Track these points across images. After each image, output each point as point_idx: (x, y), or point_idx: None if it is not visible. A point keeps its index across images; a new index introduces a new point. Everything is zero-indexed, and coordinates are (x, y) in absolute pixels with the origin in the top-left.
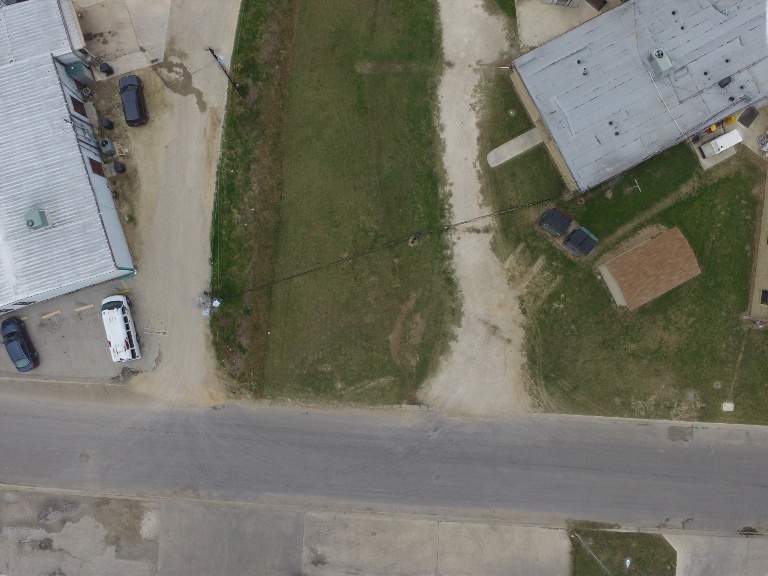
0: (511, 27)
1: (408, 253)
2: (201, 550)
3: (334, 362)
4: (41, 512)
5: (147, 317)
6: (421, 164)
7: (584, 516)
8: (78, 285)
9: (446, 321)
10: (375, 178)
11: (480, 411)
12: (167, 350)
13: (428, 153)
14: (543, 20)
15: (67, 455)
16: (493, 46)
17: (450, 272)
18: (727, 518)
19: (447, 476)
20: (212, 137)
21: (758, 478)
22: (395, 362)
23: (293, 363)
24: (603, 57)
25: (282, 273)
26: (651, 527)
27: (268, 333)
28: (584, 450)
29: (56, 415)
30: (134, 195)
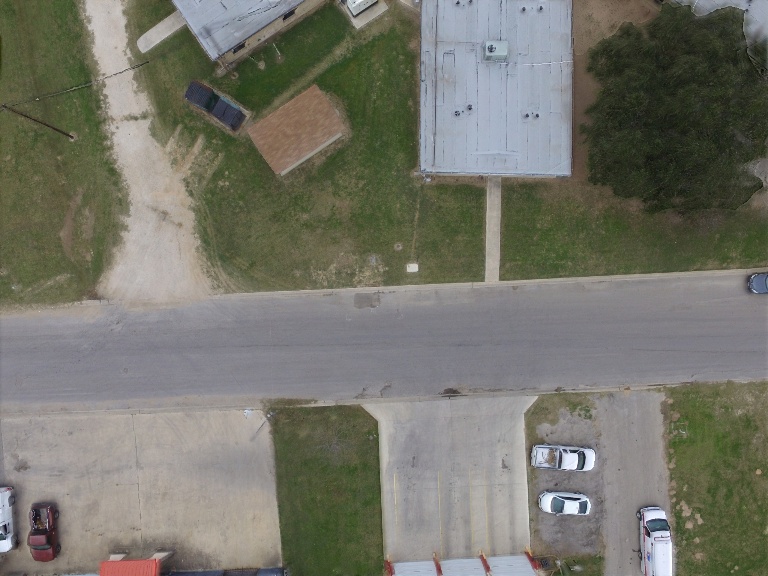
0: None
1: (70, 149)
2: None
3: (8, 265)
4: None
5: None
6: (72, 58)
7: (278, 394)
8: None
9: (114, 212)
10: (30, 78)
11: (160, 299)
12: None
13: (78, 47)
14: None
15: None
16: None
17: (112, 162)
18: (426, 382)
19: (135, 368)
20: None
21: (453, 337)
22: (69, 259)
23: None
24: None
25: None
26: (349, 399)
27: None
28: (269, 327)
29: None
30: None
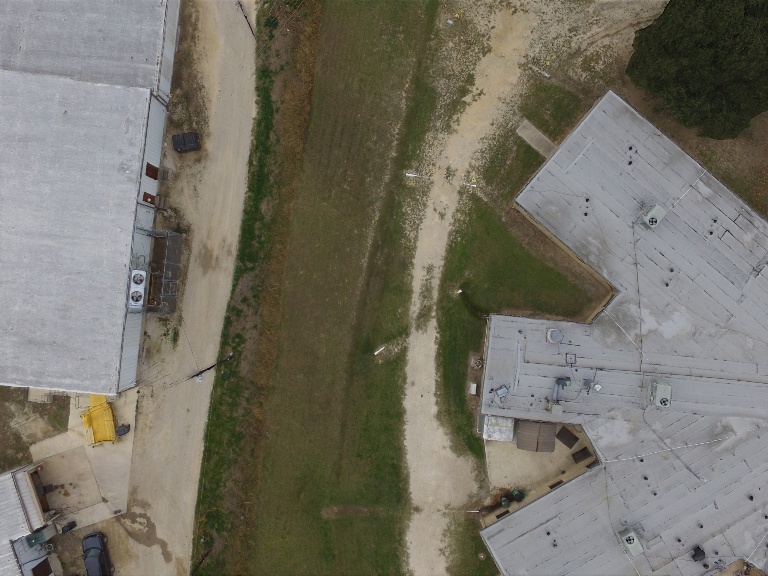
0: (481, 469)
1: None
2: None
3: None
4: None
5: None
6: None
7: None
8: None
9: None
10: None
11: None
12: None
13: None
14: (513, 460)
15: None
16: (462, 489)
17: None
18: None
19: None
20: None
21: None
22: None
23: None
24: (574, 526)
25: None
26: None
27: None
28: None
29: None
30: None
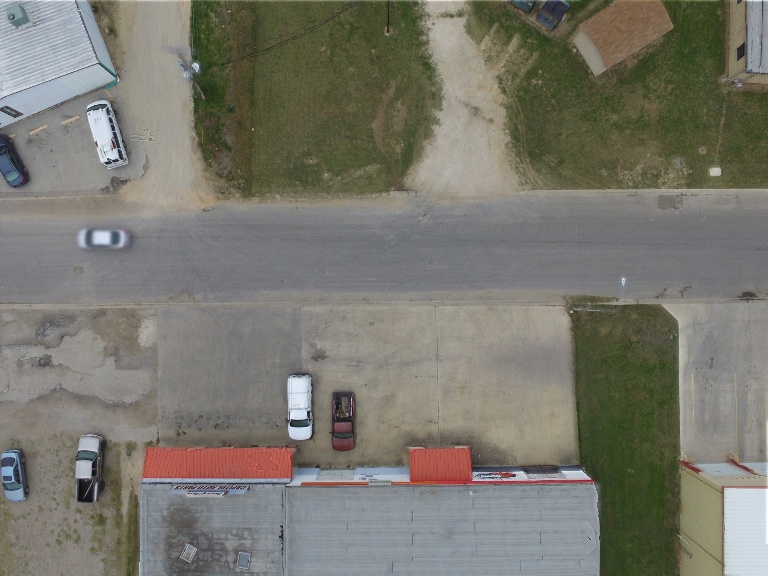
0: None
1: (384, 43)
2: (200, 353)
3: (319, 153)
4: (39, 328)
5: (132, 124)
6: None
7: (581, 291)
8: (62, 89)
9: (427, 105)
10: None
11: (468, 193)
12: (154, 156)
13: None
14: None
15: (61, 269)
16: None
17: (427, 57)
18: (725, 284)
19: (440, 260)
20: None
21: (753, 241)
22: (380, 149)
23: (279, 157)
24: None
25: (262, 71)
26: (650, 298)
27: (252, 129)
28: (575, 224)
29: (48, 231)
30: (113, 8)
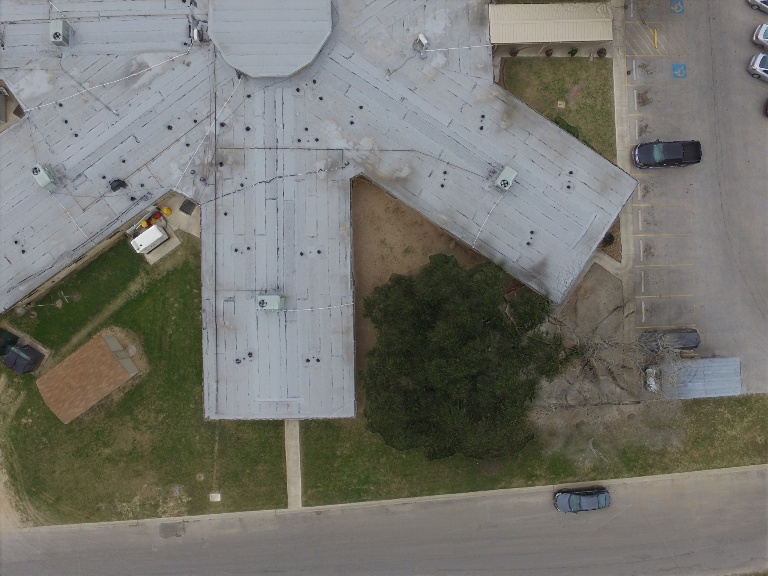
0: None
1: None
2: None
3: None
4: None
5: None
6: None
7: None
8: None
9: None
10: None
11: None
12: None
13: None
14: None
15: None
16: None
17: None
18: None
19: None
20: None
21: (258, 564)
22: None
23: None
24: (4, 177)
25: None
26: None
27: None
28: (78, 558)
29: None
30: None
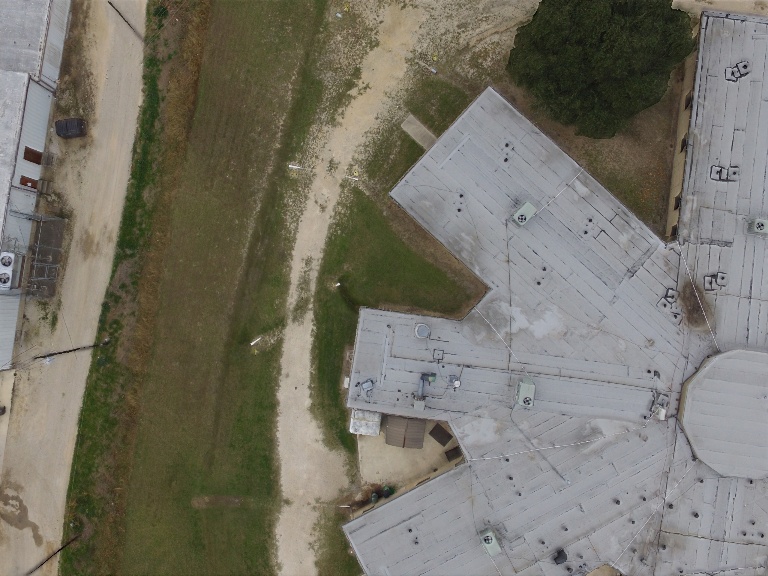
0: (352, 463)
1: None
2: None
3: None
4: None
5: None
6: None
7: None
8: None
9: None
10: None
11: None
12: None
13: None
14: (386, 456)
15: None
16: (334, 483)
17: None
18: None
19: None
20: (48, 572)
21: None
22: None
23: None
24: (437, 524)
25: None
26: None
27: None
28: None
29: None
30: None
